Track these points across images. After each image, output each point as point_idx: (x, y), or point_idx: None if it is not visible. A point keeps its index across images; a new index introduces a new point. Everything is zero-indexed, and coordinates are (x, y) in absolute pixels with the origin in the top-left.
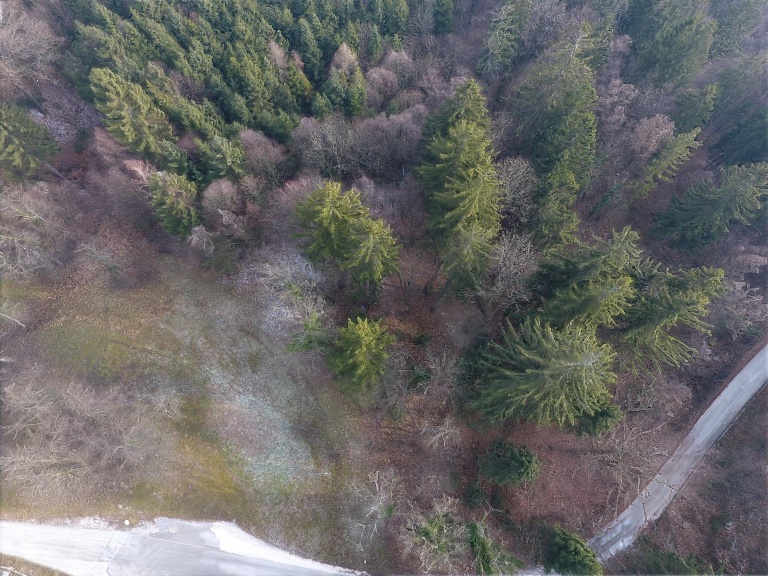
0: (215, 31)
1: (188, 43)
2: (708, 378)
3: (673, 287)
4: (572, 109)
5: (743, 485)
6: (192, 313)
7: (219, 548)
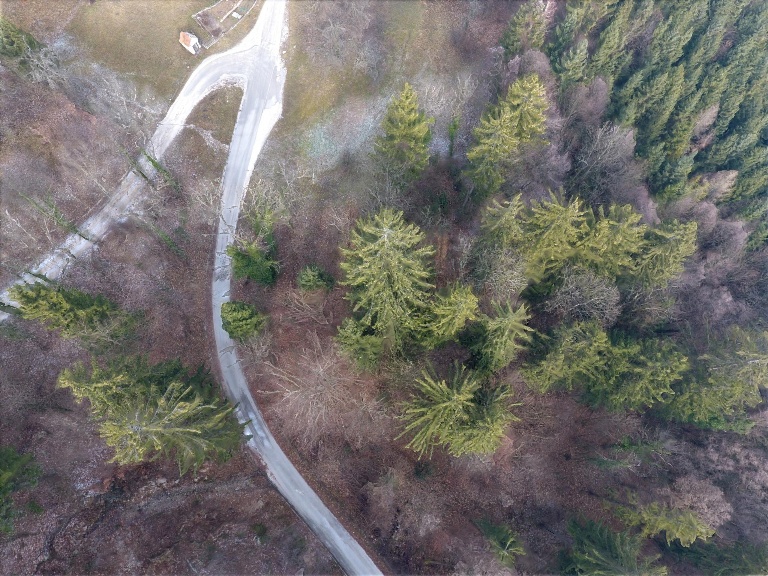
0: (716, 63)
1: (695, 45)
2: (406, 571)
3: (482, 410)
4: (706, 386)
5: (294, 569)
6: (438, 86)
7: (265, 109)
